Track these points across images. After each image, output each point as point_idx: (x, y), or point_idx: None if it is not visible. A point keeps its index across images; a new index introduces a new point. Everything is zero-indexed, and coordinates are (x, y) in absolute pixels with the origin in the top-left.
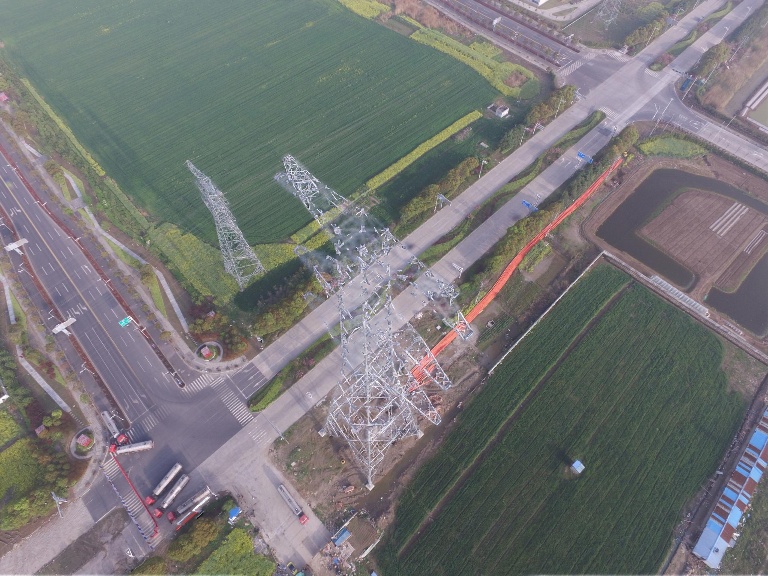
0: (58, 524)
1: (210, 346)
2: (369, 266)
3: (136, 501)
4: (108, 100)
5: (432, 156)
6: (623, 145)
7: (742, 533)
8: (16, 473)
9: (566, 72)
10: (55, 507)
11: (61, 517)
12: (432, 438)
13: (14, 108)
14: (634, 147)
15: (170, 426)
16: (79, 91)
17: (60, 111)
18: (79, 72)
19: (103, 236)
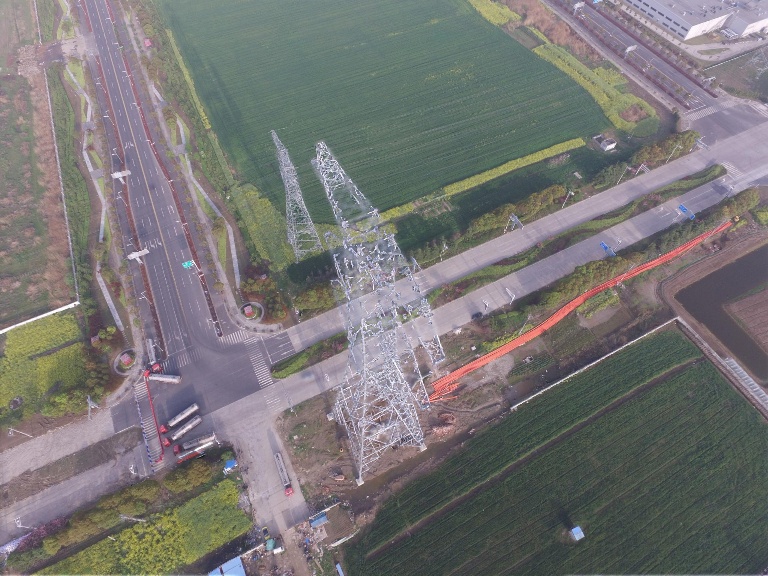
0: (86, 424)
1: (254, 306)
2: (422, 270)
3: (153, 426)
4: (232, 61)
5: (519, 175)
6: (736, 208)
7: None
8: (67, 370)
9: (694, 116)
10: (88, 409)
11: (90, 419)
12: (434, 455)
13: (154, 54)
14: (750, 213)
15: (199, 368)
16: (210, 49)
17: (190, 64)
18: (215, 32)
19: (193, 183)
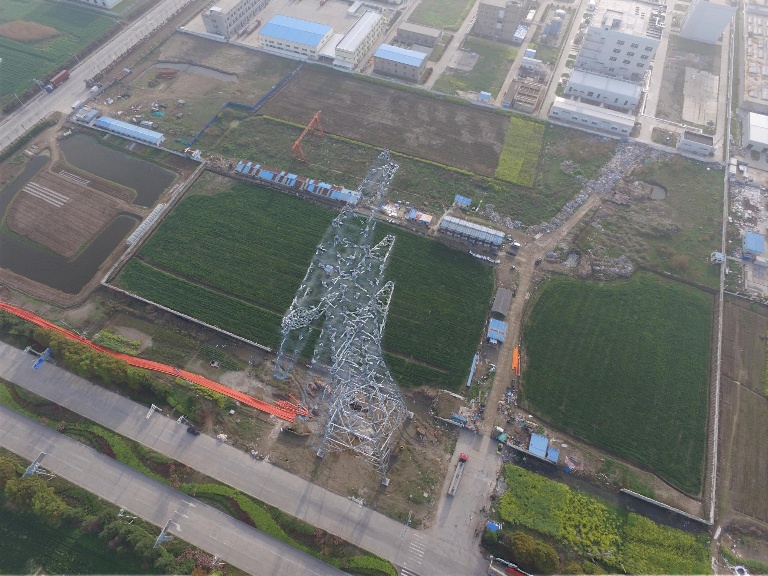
0: None
1: None
2: None
3: None
4: None
5: None
6: None
7: (332, 183)
8: None
9: None
10: None
11: None
12: None
13: None
14: None
15: None
16: None
17: None
18: None
19: None
